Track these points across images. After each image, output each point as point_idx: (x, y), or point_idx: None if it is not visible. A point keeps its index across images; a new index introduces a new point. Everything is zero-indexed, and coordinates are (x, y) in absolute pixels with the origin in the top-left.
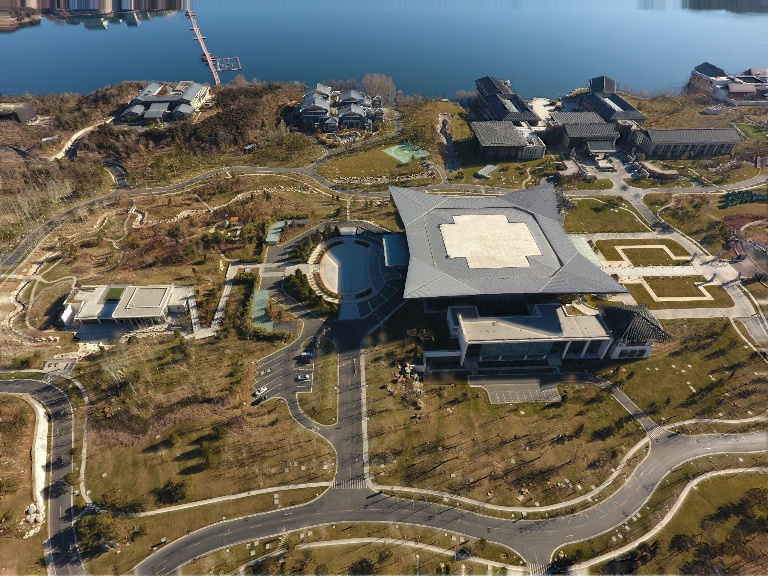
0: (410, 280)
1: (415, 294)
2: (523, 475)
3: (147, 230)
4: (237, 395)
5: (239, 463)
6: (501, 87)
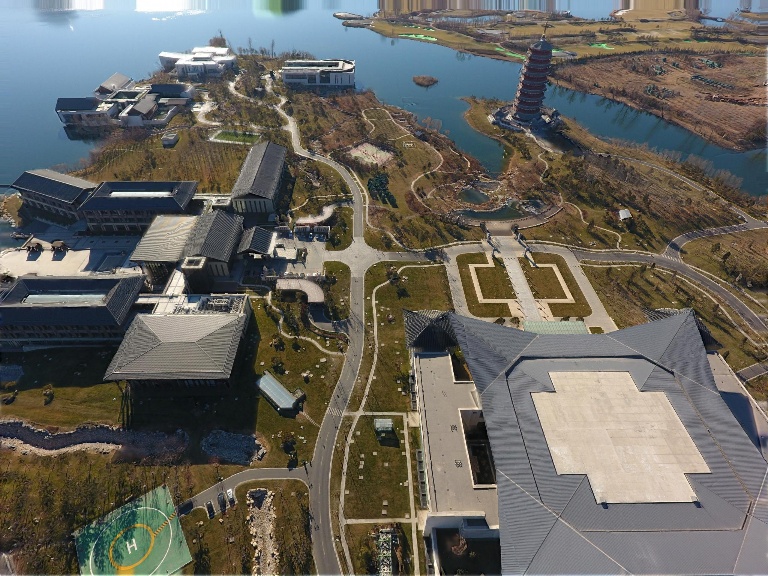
0: None
1: None
2: None
3: None
4: None
5: None
6: None
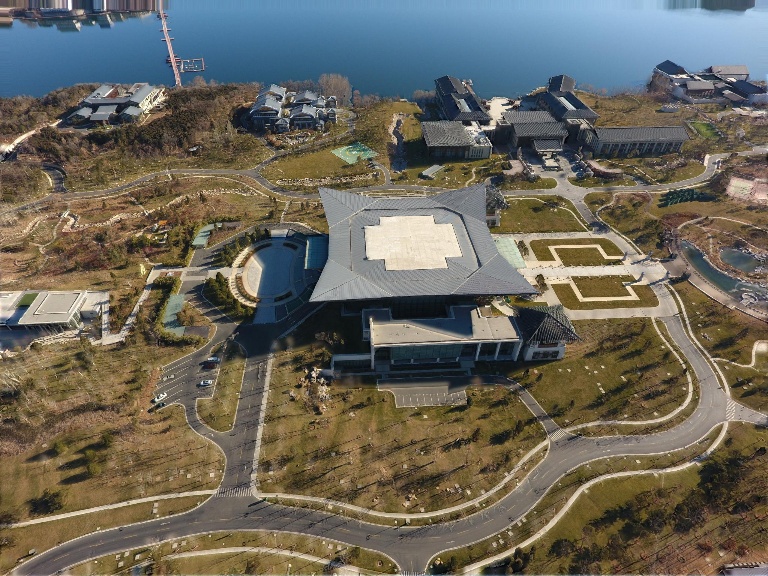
0: (321, 283)
1: (322, 297)
2: (413, 480)
3: (76, 234)
4: (135, 402)
5: (124, 472)
6: (459, 86)
